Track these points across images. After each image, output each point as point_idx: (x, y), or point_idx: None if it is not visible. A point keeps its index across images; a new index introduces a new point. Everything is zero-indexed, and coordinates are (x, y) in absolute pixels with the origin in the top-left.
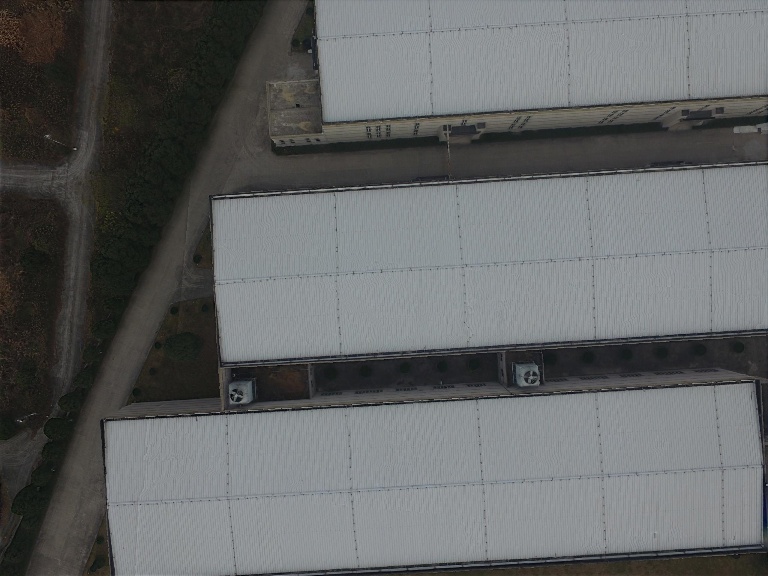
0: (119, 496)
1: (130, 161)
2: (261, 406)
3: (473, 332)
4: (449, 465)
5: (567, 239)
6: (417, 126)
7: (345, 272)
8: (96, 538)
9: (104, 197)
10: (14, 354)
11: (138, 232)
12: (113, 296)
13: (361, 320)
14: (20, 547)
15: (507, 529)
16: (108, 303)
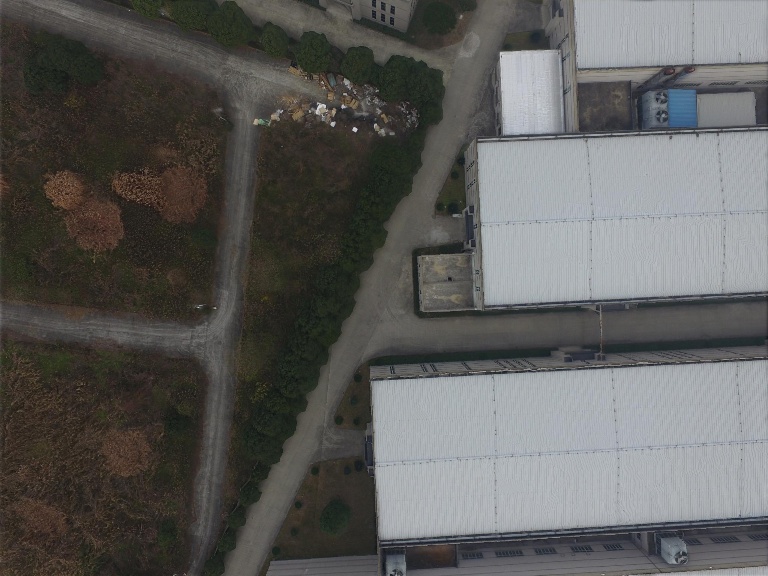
0: None
1: (272, 323)
2: None
3: (630, 517)
4: None
5: (718, 423)
6: None
7: (504, 455)
8: None
9: (254, 368)
10: (151, 513)
11: (291, 405)
12: None
13: (517, 500)
14: None
15: None
16: (258, 474)
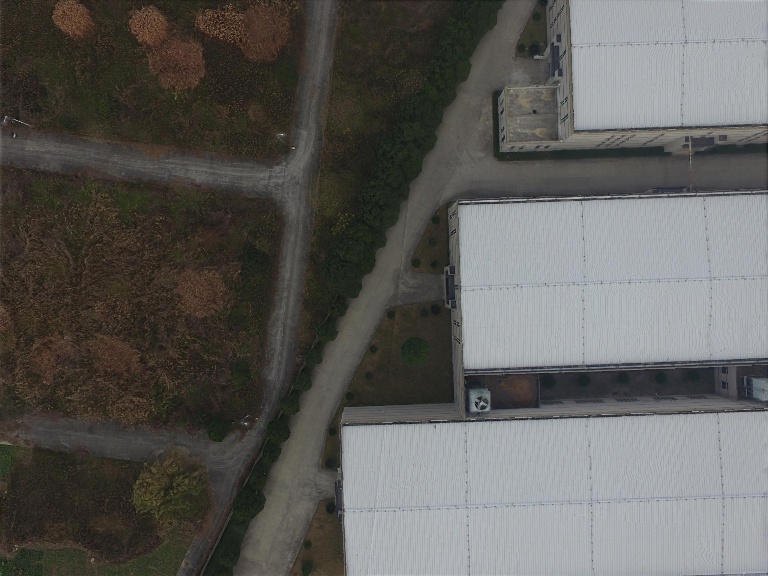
0: (356, 502)
1: (351, 162)
2: (498, 414)
3: (725, 345)
4: (690, 478)
5: None
6: (658, 136)
7: (593, 282)
8: (303, 543)
9: (336, 198)
10: (225, 355)
11: (373, 235)
12: (328, 298)
13: (605, 330)
14: (235, 551)
15: (744, 543)
16: (338, 306)
